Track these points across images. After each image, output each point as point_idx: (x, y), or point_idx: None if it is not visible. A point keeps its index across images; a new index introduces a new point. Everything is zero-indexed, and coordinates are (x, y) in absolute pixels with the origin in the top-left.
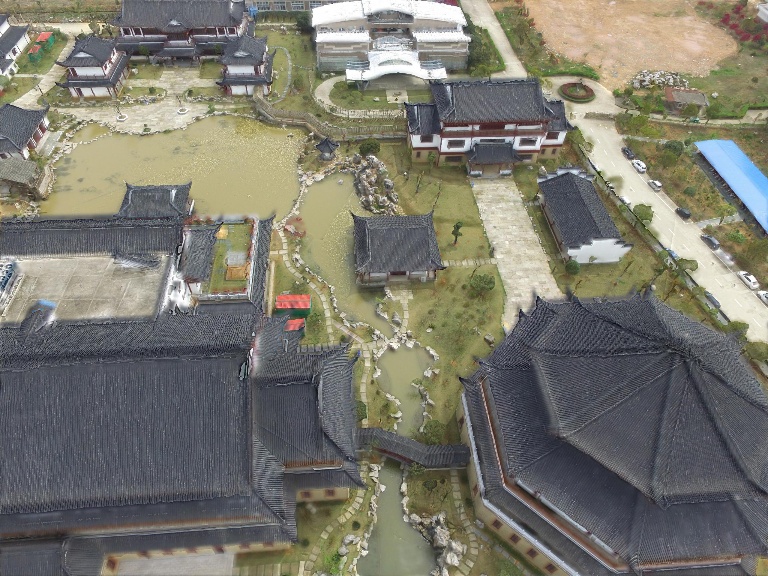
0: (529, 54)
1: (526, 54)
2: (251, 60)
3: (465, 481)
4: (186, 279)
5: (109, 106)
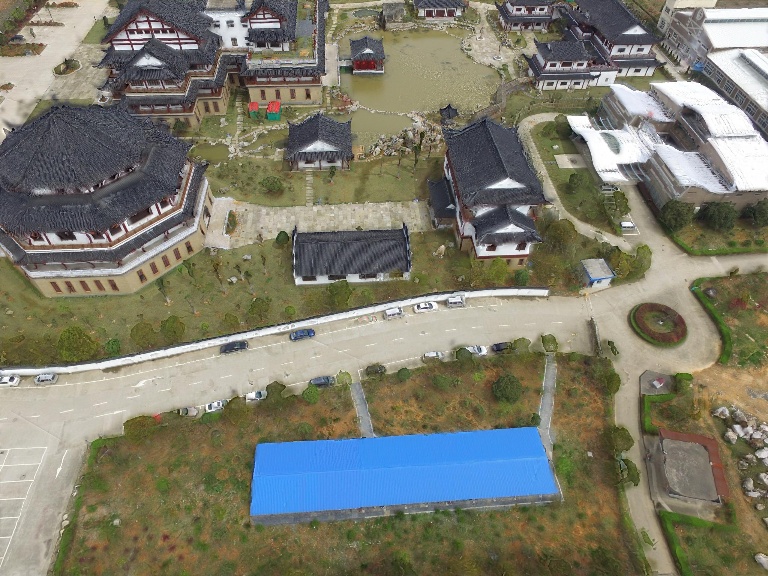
0: (763, 289)
1: (760, 285)
2: (548, 54)
3: None
4: (249, 34)
5: (495, 33)
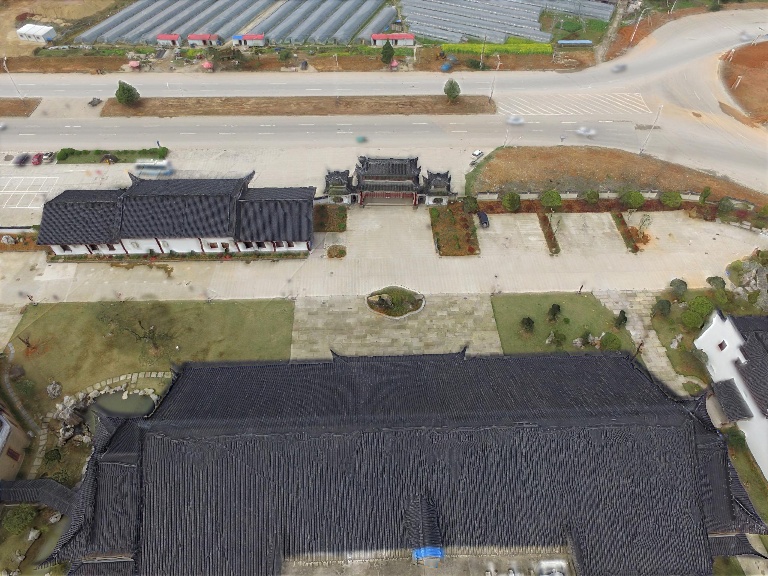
0: None
1: None
2: None
3: (21, 473)
4: None
5: None
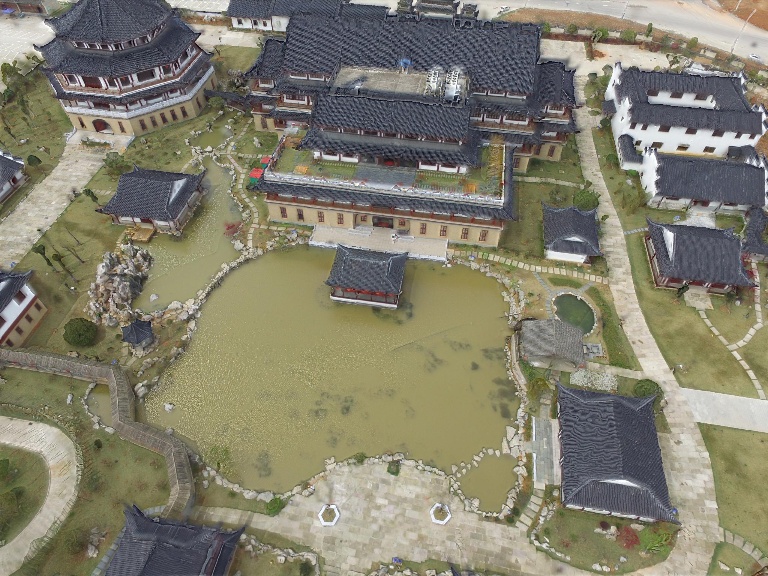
0: None
1: None
2: (147, 534)
3: None
4: None
5: (474, 570)
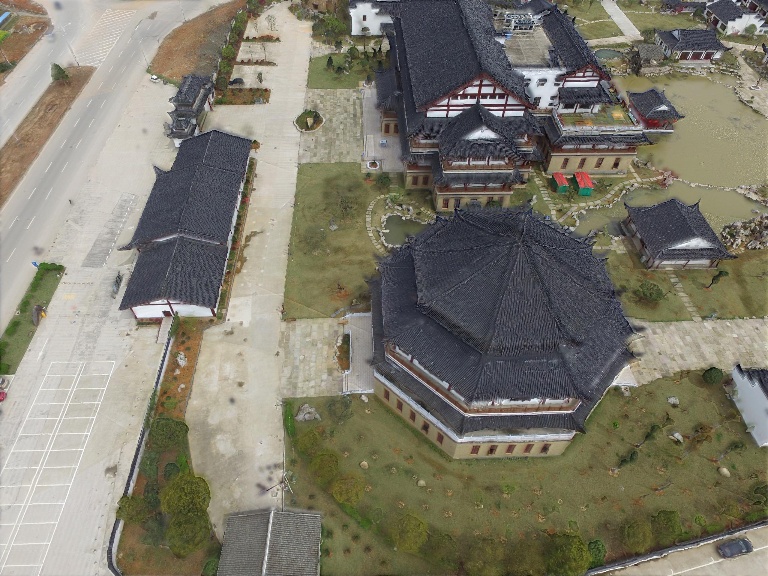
0: None
1: None
2: None
3: None
4: (560, 94)
5: (767, 80)
